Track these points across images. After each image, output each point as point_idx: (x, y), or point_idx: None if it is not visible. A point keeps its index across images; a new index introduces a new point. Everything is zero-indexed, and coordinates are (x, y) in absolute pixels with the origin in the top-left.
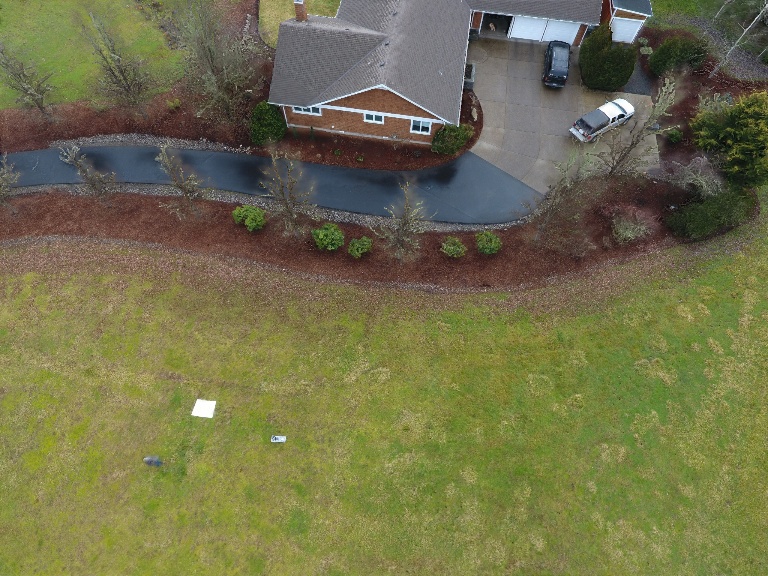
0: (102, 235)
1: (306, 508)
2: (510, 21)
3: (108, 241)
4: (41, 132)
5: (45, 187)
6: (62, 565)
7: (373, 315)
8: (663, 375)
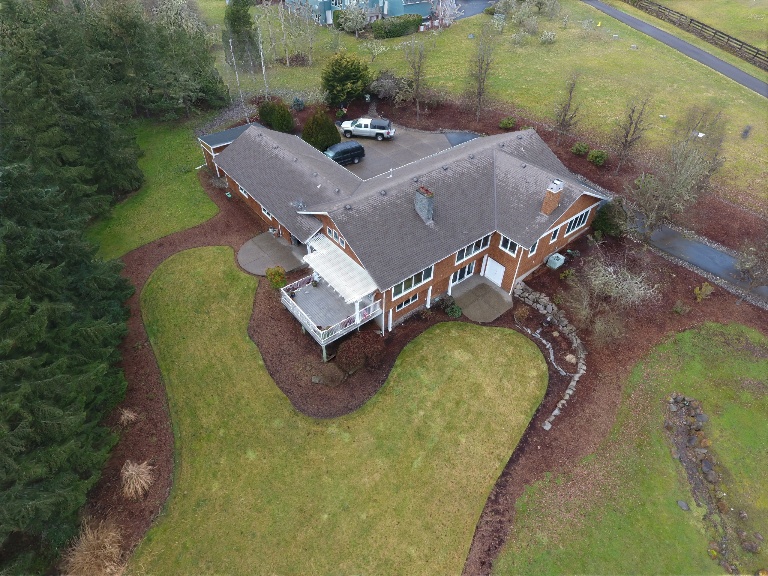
0: None
1: None
2: None
3: (766, 218)
4: None
5: None
6: (767, 123)
7: None
8: None
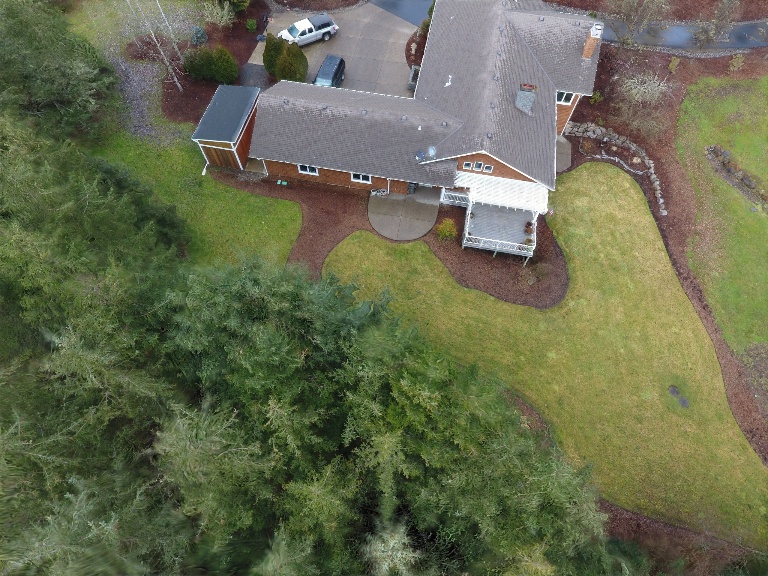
0: None
1: None
2: None
3: None
4: (765, 54)
5: None
6: None
7: None
8: None
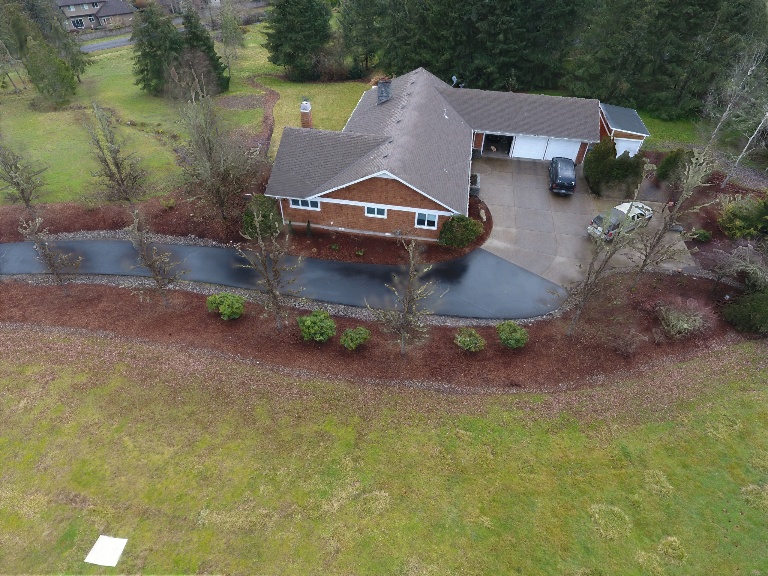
0: (46, 322)
1: None
2: (511, 141)
3: (51, 329)
4: None
5: (3, 277)
6: None
7: (368, 419)
8: None
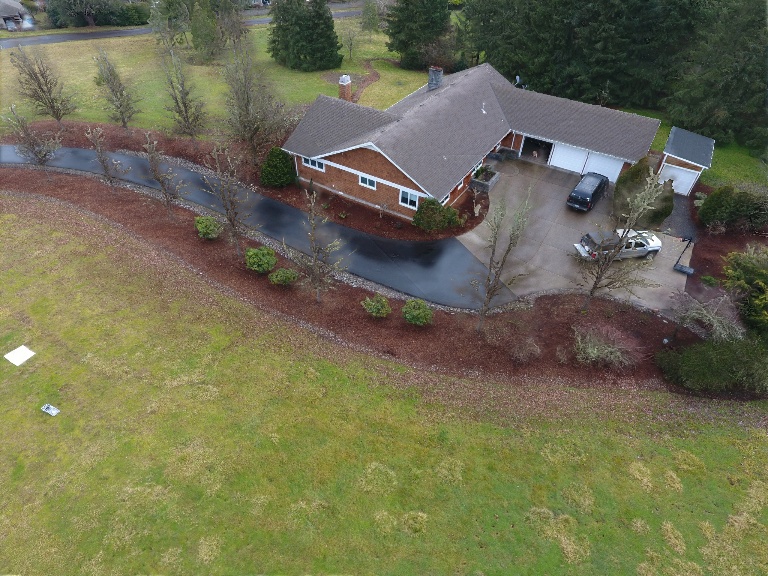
0: (88, 208)
1: (4, 494)
2: (550, 148)
3: (88, 213)
4: (117, 141)
5: (88, 173)
6: None
7: (247, 336)
8: (566, 542)
